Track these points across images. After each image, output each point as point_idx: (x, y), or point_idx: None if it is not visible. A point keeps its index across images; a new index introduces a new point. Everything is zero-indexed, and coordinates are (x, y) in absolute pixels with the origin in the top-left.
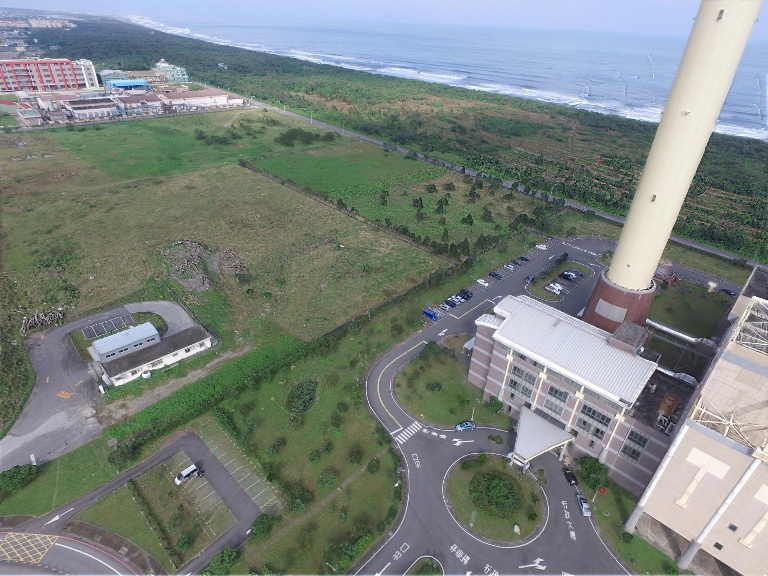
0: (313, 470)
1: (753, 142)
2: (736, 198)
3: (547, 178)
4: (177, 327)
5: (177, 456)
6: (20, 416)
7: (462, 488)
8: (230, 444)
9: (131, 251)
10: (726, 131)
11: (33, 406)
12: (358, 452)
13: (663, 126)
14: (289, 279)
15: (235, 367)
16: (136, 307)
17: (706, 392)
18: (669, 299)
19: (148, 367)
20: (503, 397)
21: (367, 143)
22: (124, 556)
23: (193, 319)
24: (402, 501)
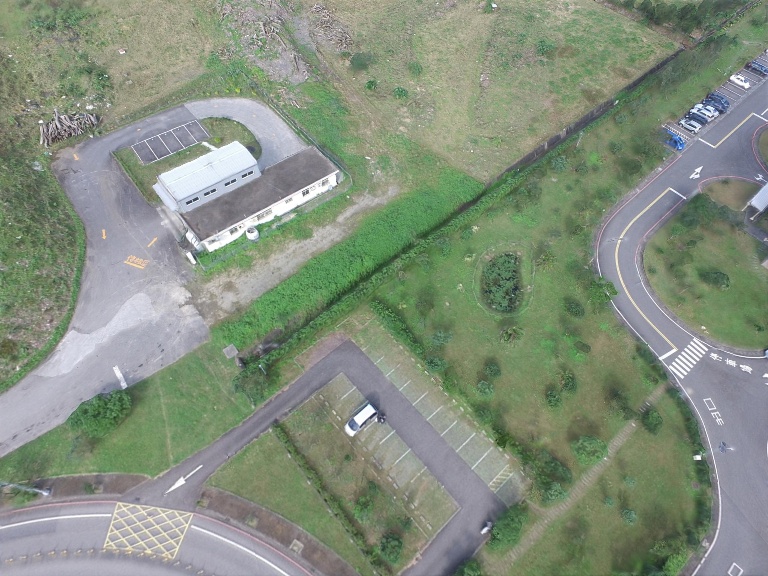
0: (555, 421)
1: None
2: None
3: None
4: (275, 147)
5: (336, 382)
6: (80, 297)
7: None
8: (413, 366)
9: (169, 5)
10: None
11: (94, 280)
12: None
13: None
14: (426, 64)
15: (385, 225)
16: (203, 108)
17: None
18: None
19: (252, 221)
20: None
21: None
22: (300, 556)
23: (296, 133)
24: (711, 486)
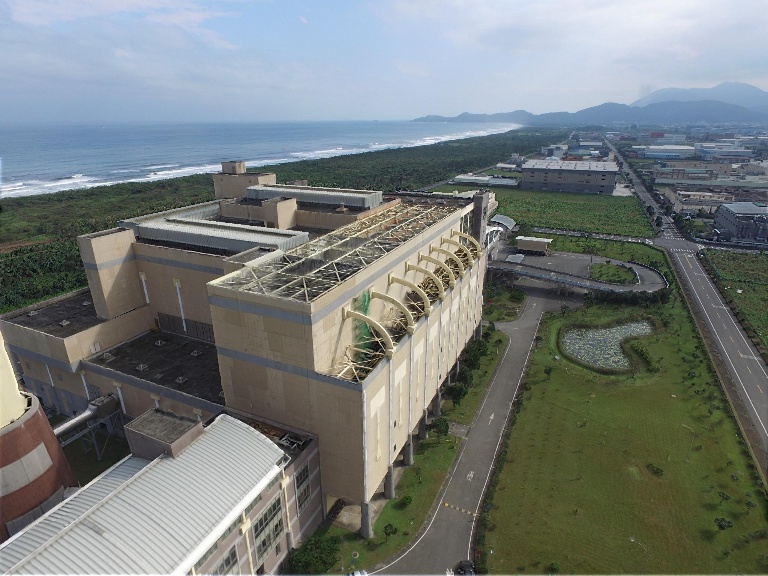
0: None
1: None
2: None
3: None
4: None
5: None
6: None
7: None
8: None
9: None
10: None
11: None
12: None
13: None
14: None
15: None
16: None
17: (317, 366)
18: None
19: None
20: None
21: None
22: None
23: None
24: None
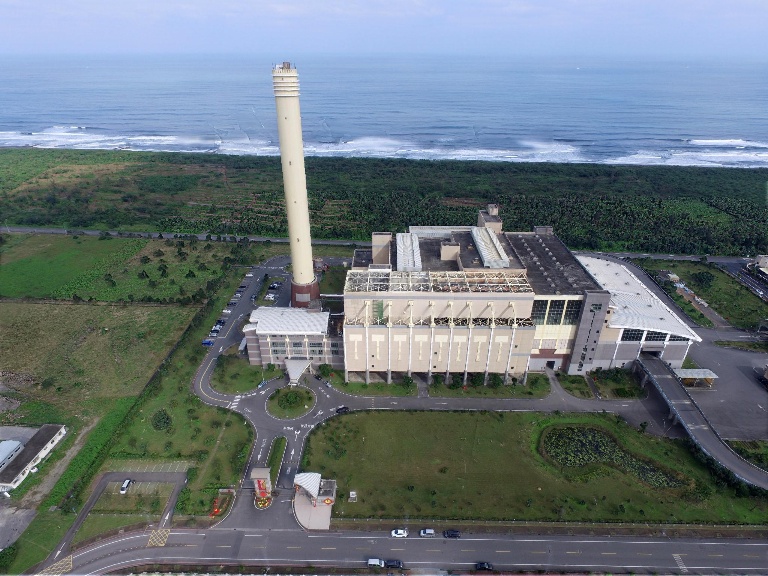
0: (198, 443)
1: (339, 160)
2: (342, 203)
3: (228, 225)
4: (21, 438)
5: (108, 486)
6: None
7: (276, 407)
8: (138, 462)
9: None
10: (322, 155)
11: None
12: (216, 422)
13: (288, 208)
14: (84, 368)
15: (100, 431)
16: None
17: (346, 313)
18: (329, 279)
19: (32, 465)
20: (273, 361)
21: (48, 235)
22: (124, 532)
23: (29, 427)
24: (252, 427)
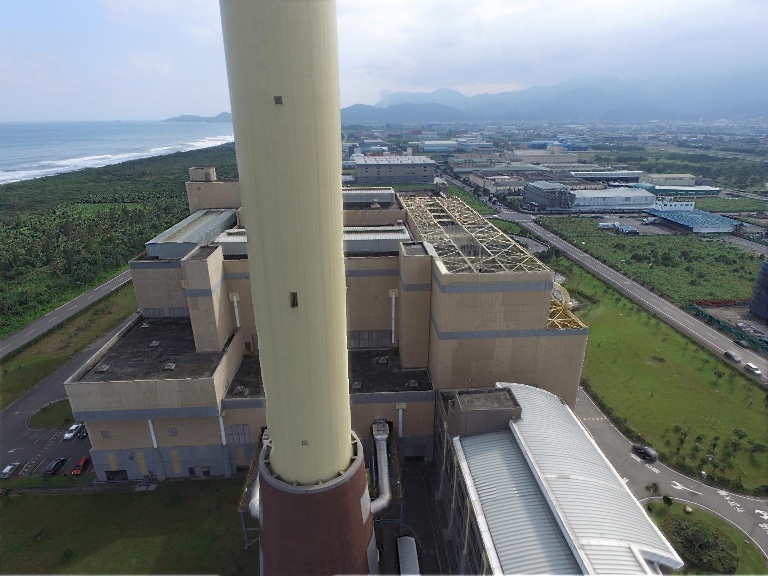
0: None
1: None
2: None
3: None
4: None
5: None
6: None
7: None
8: None
9: None
10: None
11: None
12: None
13: (327, 139)
14: None
15: None
16: None
17: None
18: (1, 575)
19: None
20: None
21: None
22: None
23: None
24: None
